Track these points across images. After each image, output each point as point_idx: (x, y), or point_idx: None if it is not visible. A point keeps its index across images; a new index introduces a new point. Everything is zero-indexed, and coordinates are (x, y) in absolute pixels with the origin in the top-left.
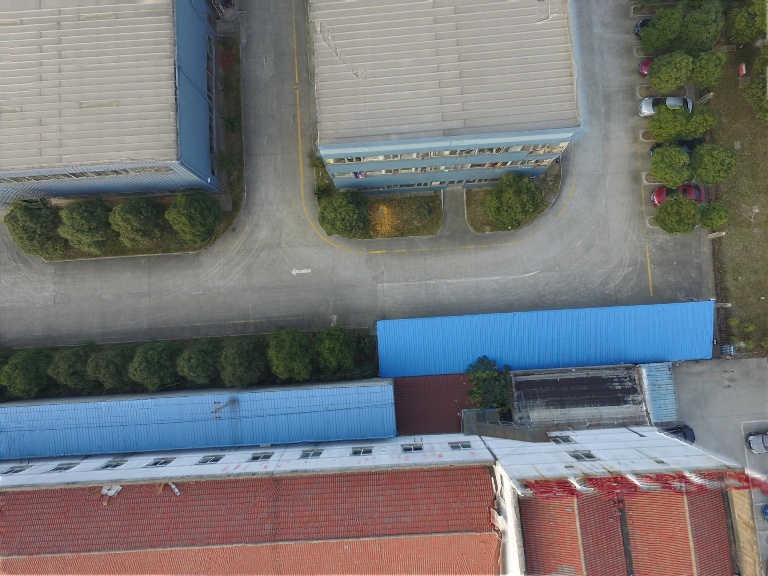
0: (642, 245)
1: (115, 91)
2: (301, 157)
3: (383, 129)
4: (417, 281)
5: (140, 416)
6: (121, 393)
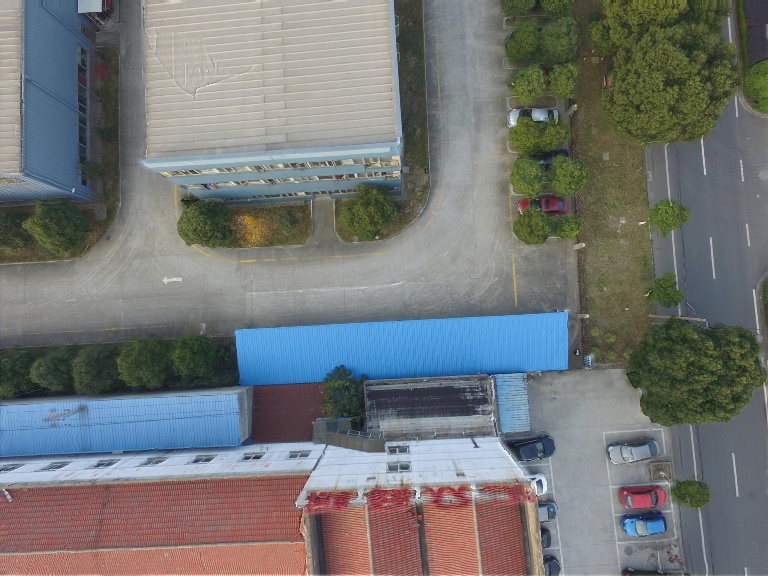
0: (508, 255)
1: None
2: None
3: (210, 143)
4: (285, 290)
5: (6, 422)
6: None
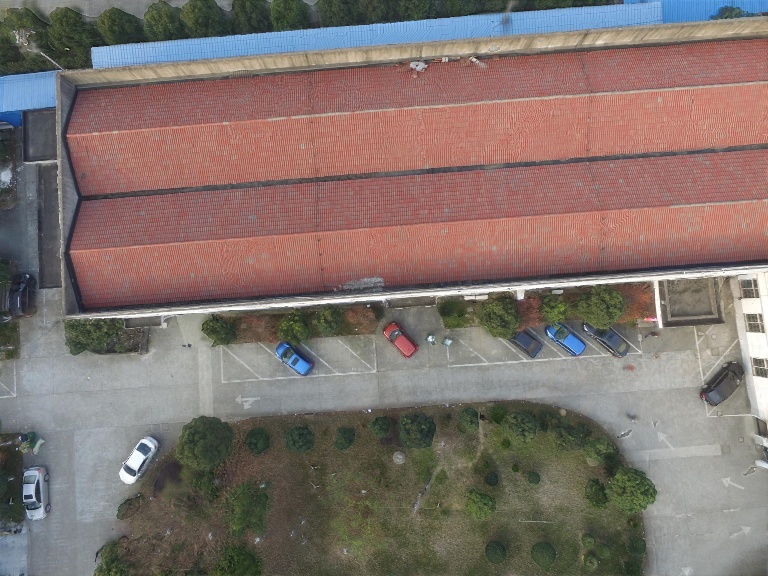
0: None
1: None
2: None
3: None
4: None
5: None
6: None
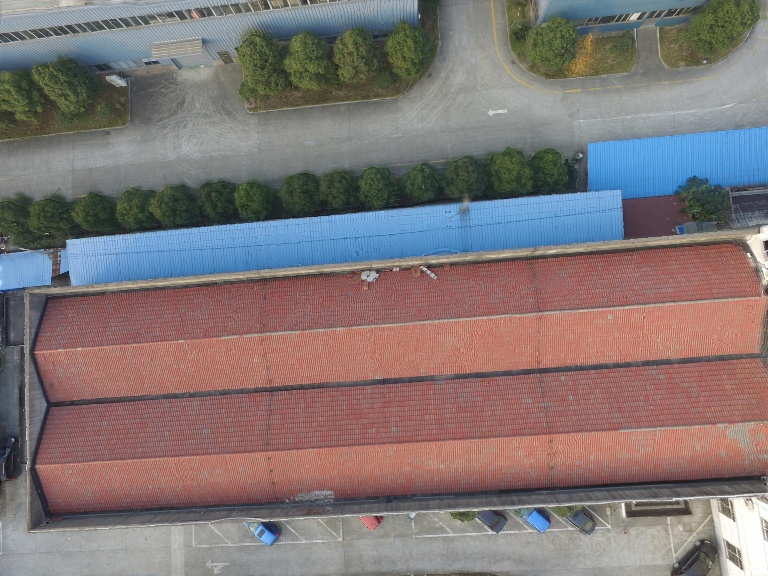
0: None
1: None
2: (492, 5)
3: None
4: (613, 117)
5: (354, 245)
6: None
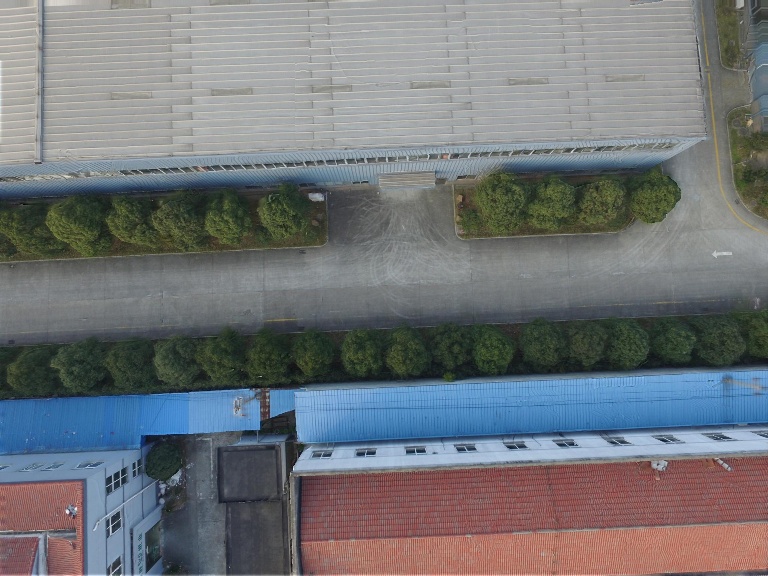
0: None
1: (635, 66)
2: (716, 140)
3: None
4: None
5: None
6: (591, 371)
